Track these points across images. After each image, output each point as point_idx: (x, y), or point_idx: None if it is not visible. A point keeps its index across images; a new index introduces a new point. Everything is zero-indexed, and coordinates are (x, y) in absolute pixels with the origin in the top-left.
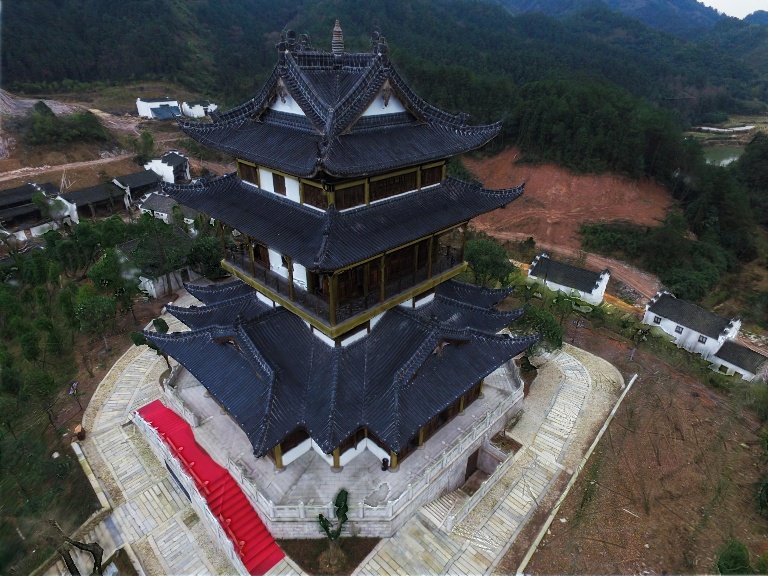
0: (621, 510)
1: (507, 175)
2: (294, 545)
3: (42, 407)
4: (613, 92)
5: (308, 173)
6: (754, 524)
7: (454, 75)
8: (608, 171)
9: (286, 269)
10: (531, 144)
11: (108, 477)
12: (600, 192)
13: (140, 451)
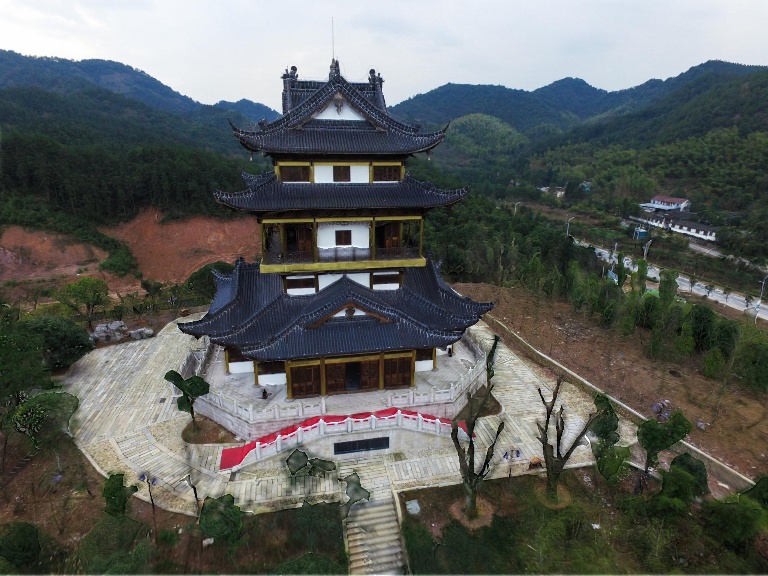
0: (525, 318)
1: (158, 235)
2: (463, 414)
3: (188, 482)
4: (212, 154)
5: (421, 147)
6: (549, 302)
7: (37, 143)
8: (248, 214)
9: (342, 246)
10: (170, 202)
11: (295, 501)
12: (251, 231)
13: (285, 474)
